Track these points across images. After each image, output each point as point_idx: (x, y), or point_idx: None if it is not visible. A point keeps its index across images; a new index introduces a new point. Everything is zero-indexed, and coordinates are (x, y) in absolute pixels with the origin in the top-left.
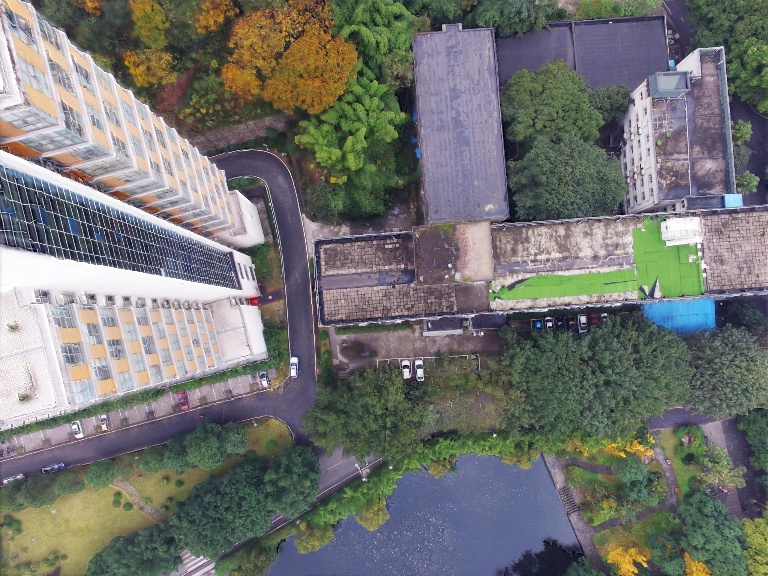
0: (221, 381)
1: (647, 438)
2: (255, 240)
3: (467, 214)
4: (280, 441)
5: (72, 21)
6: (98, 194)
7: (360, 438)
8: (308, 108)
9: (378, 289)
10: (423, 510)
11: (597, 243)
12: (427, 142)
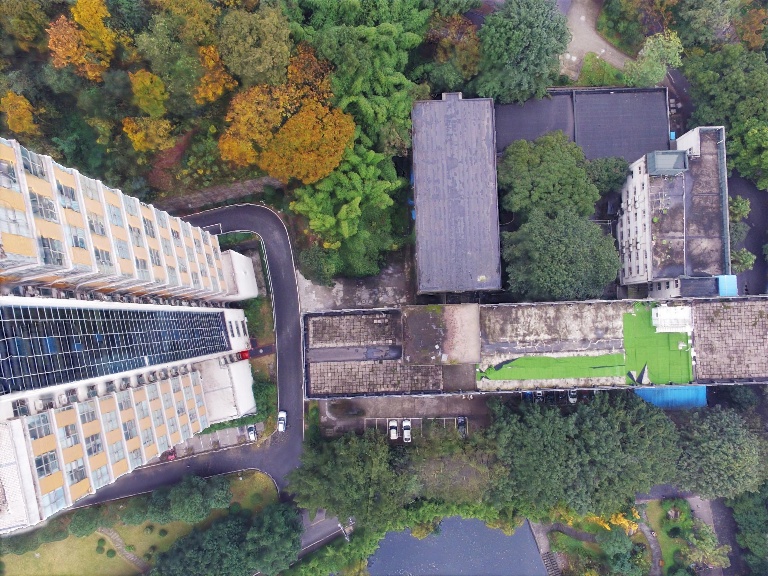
0: (209, 433)
1: (632, 513)
2: (248, 296)
3: (459, 284)
4: (265, 494)
5: (72, 88)
6: (81, 303)
7: (342, 506)
8: (303, 178)
9: (365, 364)
10: (405, 569)
11: (587, 326)
12: (422, 210)
